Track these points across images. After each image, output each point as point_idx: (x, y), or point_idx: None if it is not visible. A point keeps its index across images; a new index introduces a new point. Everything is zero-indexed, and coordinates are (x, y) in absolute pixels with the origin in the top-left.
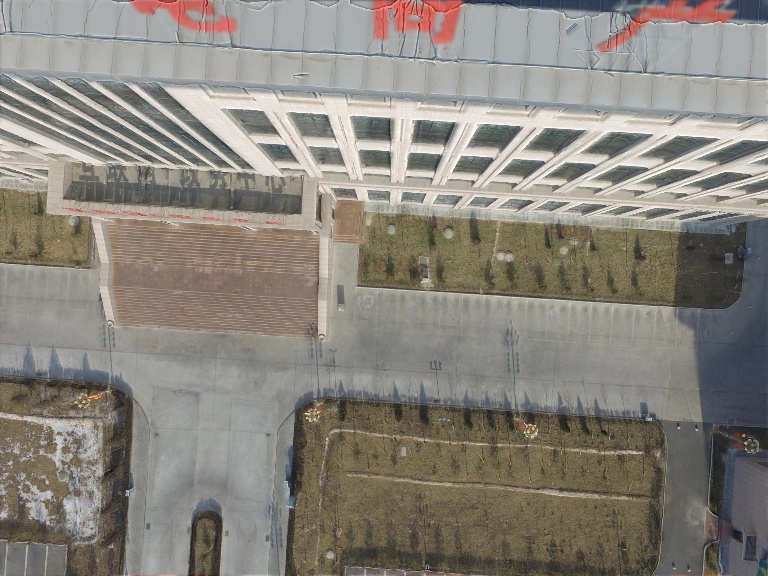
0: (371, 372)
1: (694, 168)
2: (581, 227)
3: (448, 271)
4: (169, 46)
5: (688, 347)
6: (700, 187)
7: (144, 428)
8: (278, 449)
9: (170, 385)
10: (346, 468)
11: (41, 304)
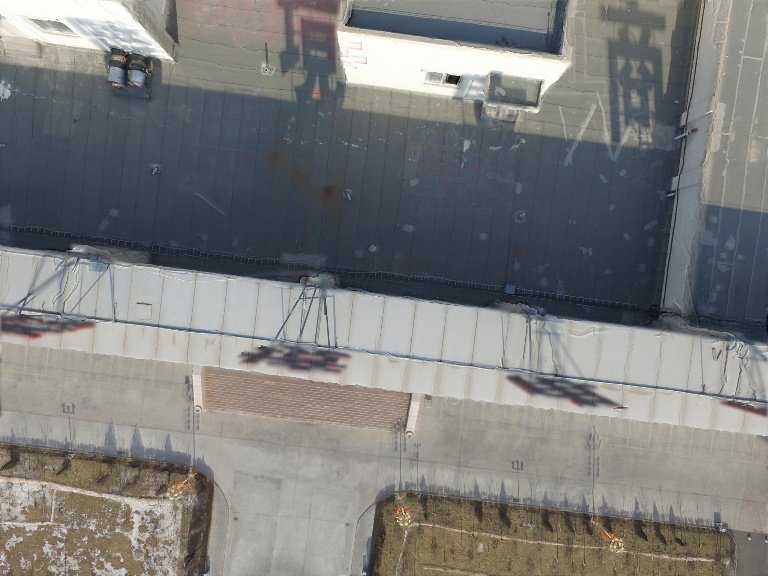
0: (453, 468)
1: None
2: None
3: None
4: (493, 371)
5: (764, 461)
6: None
7: (224, 512)
8: (357, 539)
9: (252, 470)
10: (423, 561)
11: (126, 382)
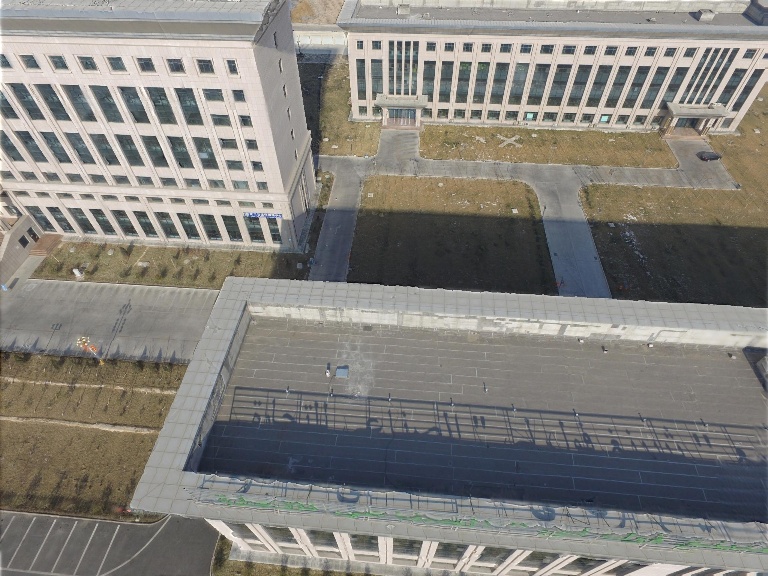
0: (2, 330)
1: (150, 132)
2: (203, 250)
3: (100, 271)
4: None
5: None
6: (194, 168)
7: None
8: None
9: None
10: None
11: None
